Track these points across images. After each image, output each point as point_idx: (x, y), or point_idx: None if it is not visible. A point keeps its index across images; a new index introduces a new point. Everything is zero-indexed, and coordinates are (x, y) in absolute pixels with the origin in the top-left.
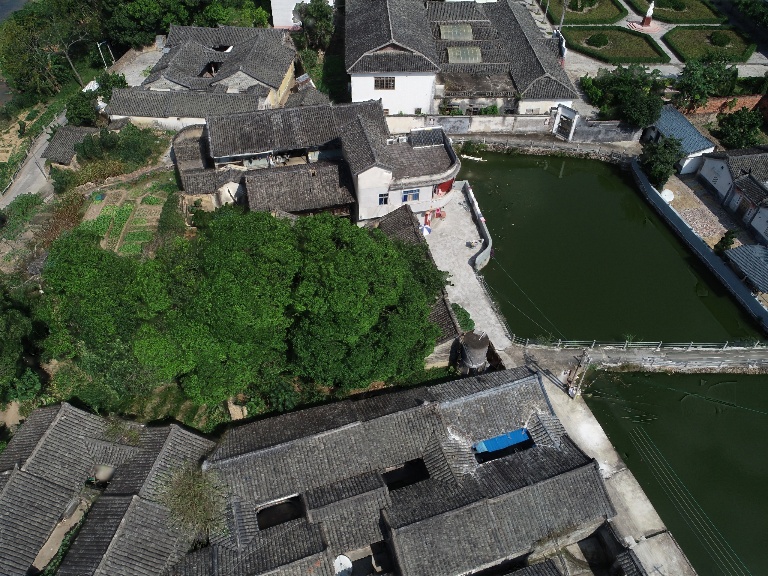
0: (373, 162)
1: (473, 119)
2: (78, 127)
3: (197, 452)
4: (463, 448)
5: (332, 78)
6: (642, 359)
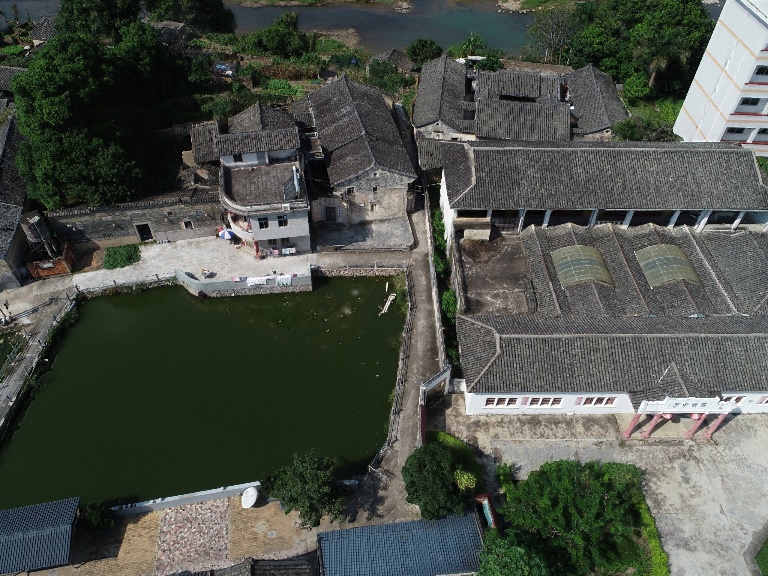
0: None
1: None
2: (410, 60)
3: None
4: None
5: None
6: None
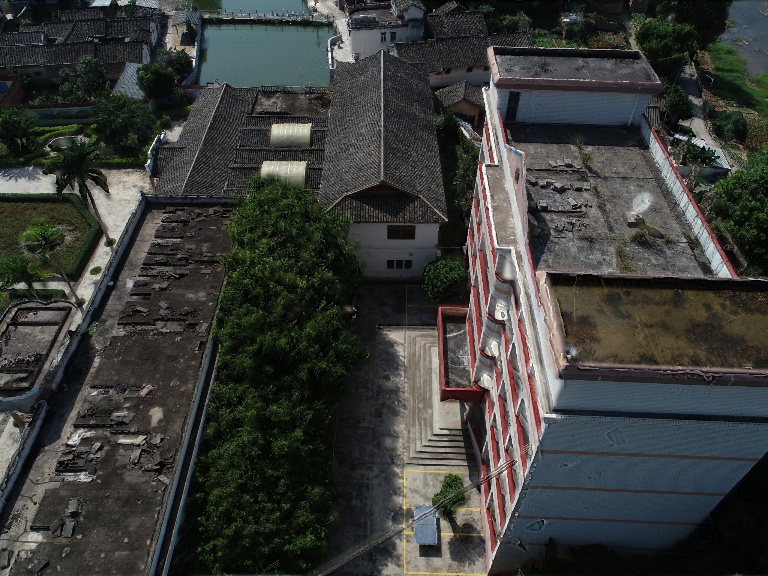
0: None
1: None
2: None
3: None
4: None
5: (449, 177)
6: (276, 16)
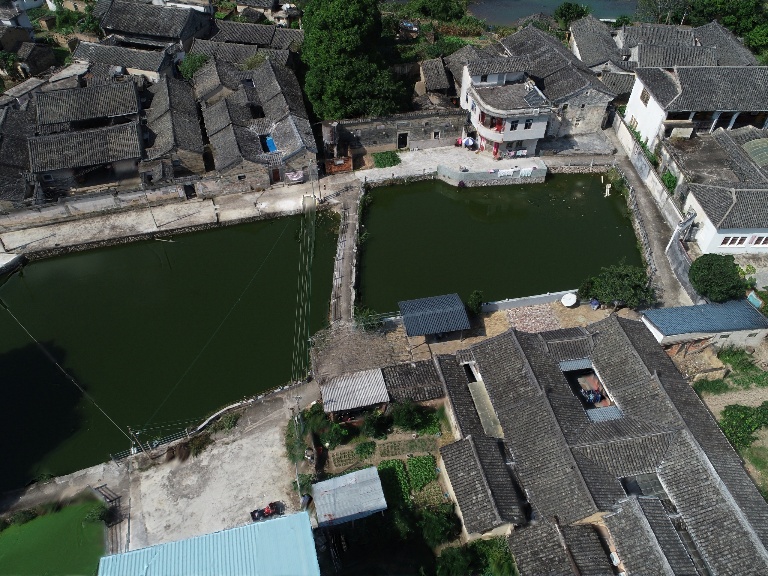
0: None
1: (651, 171)
2: (554, 21)
3: (280, 62)
4: (268, 129)
5: None
6: None
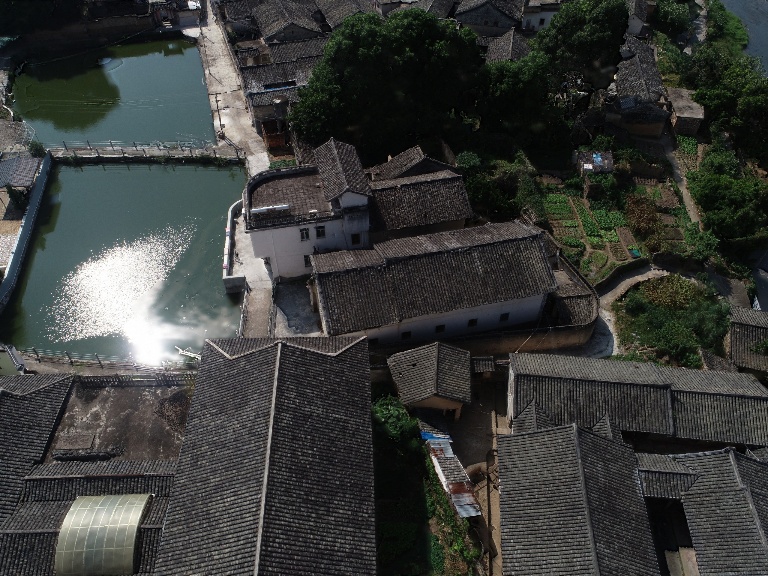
0: (336, 141)
1: None
2: None
3: None
4: (301, 83)
5: None
6: None
